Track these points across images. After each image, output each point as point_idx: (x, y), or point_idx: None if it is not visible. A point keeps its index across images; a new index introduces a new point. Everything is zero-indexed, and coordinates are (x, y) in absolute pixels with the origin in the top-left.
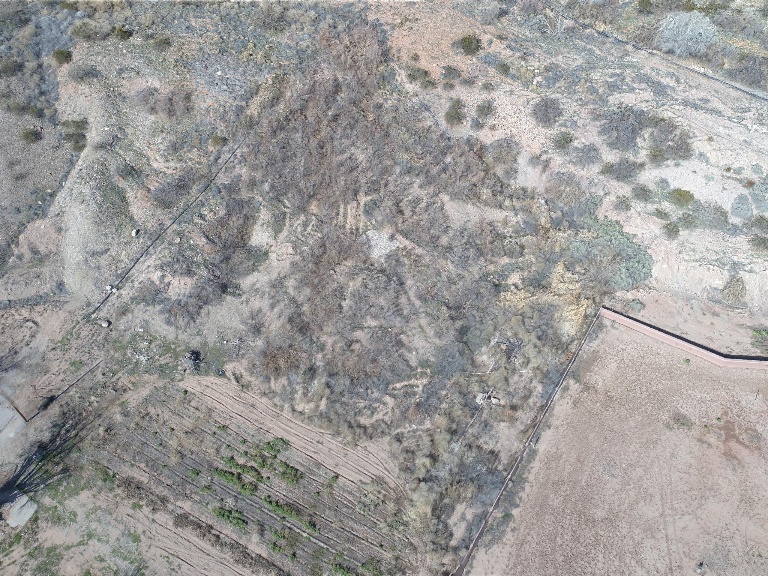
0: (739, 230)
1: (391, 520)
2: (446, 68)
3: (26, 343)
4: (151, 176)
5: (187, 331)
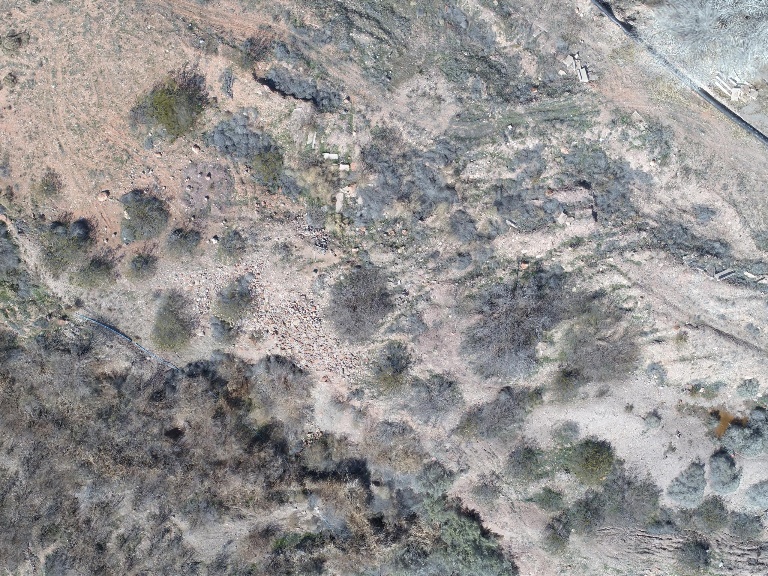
0: (668, 528)
1: None
2: (130, 204)
3: None
4: None
5: None
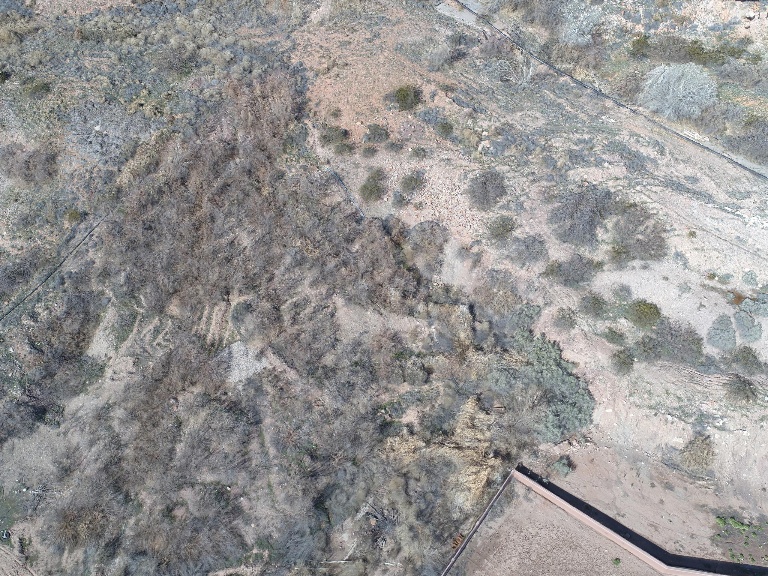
0: (714, 367)
1: None
2: (372, 127)
3: None
4: None
5: None
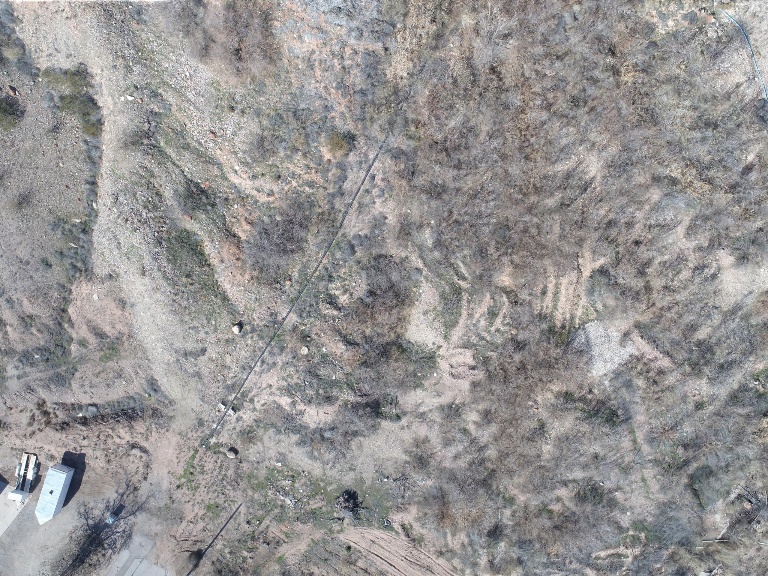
0: None
1: None
2: None
3: (142, 476)
4: (233, 204)
5: (336, 467)
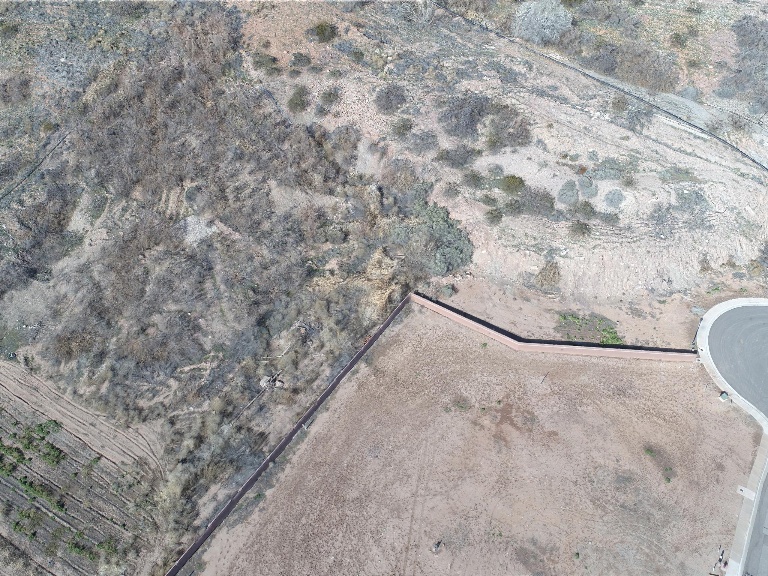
0: (562, 216)
1: (140, 500)
2: (296, 55)
3: None
4: None
5: None
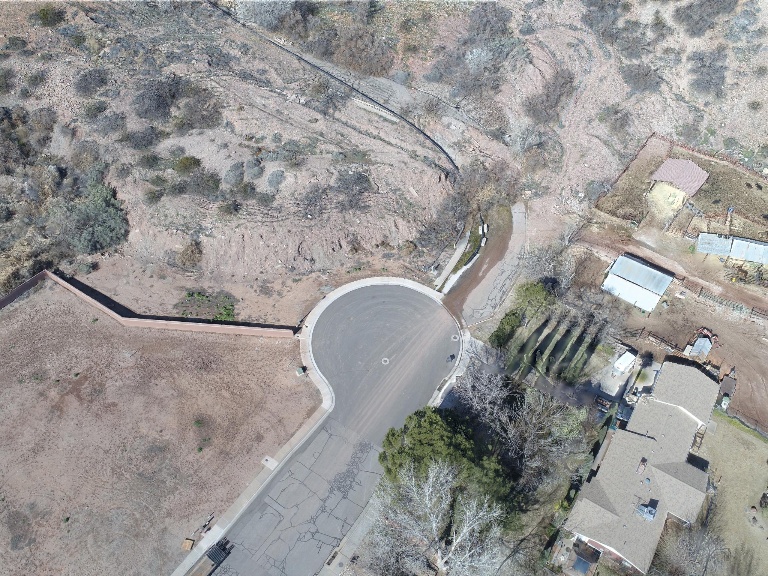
0: (220, 196)
1: None
2: (12, 39)
3: None
4: None
5: None
